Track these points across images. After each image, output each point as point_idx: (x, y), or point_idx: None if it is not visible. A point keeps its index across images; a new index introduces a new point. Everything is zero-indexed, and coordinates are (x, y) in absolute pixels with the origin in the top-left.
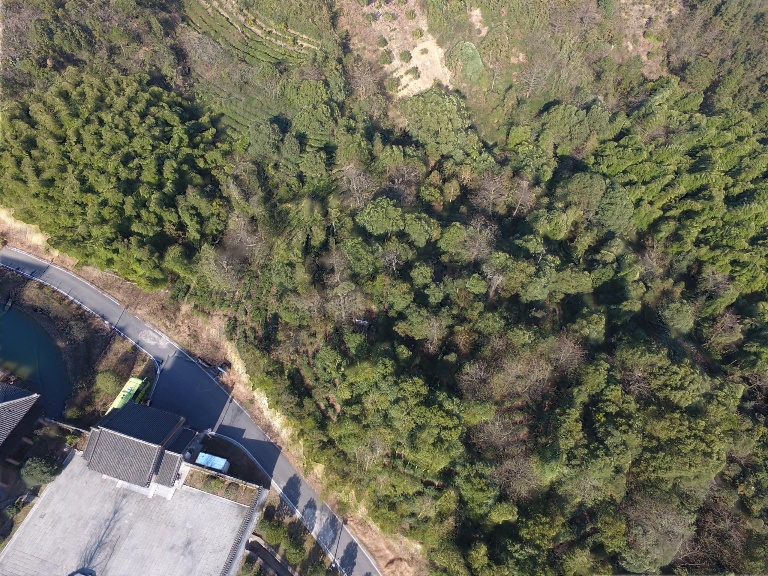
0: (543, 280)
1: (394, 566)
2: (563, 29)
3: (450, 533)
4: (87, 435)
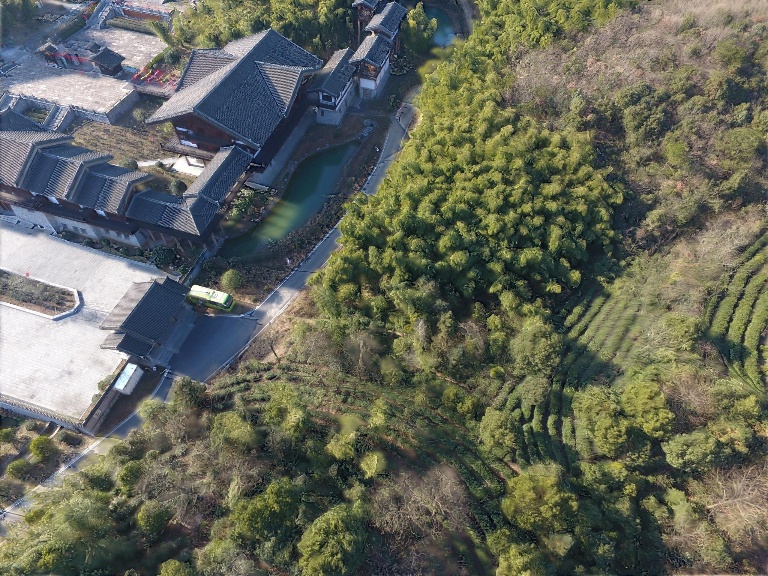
0: None
1: None
2: None
3: None
4: None
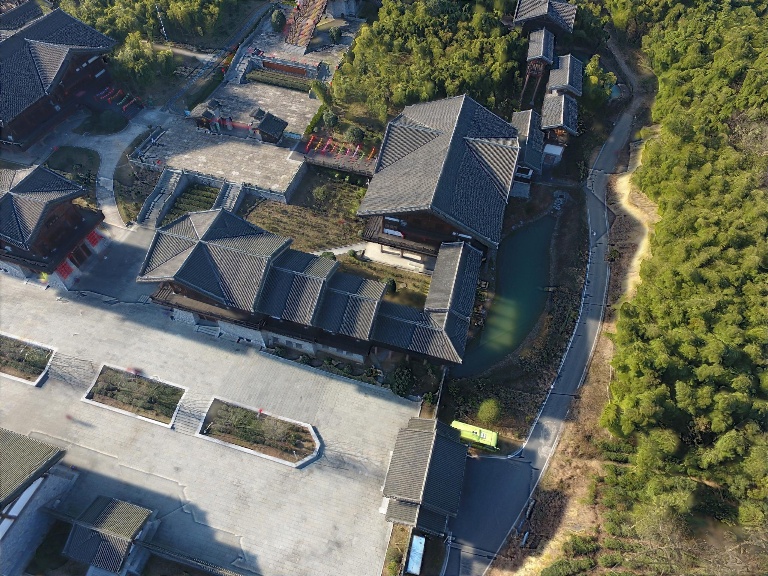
0: None
1: None
2: None
3: None
4: None
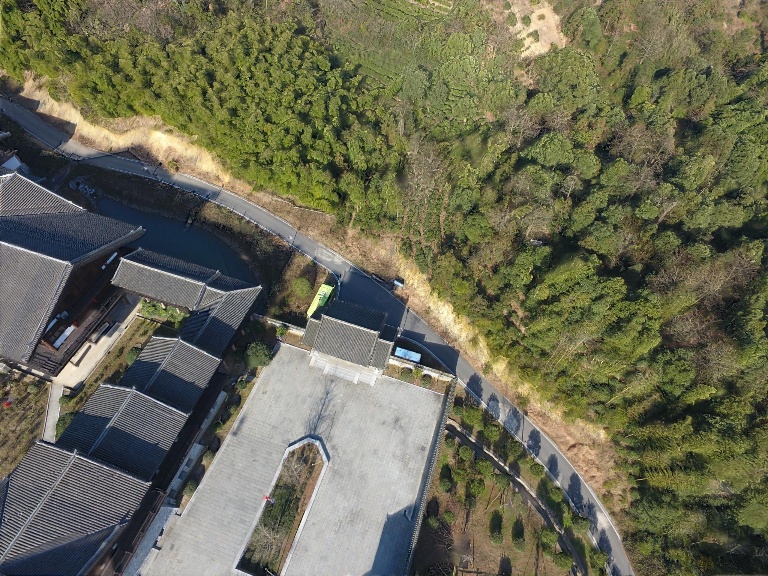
0: (710, 208)
1: (576, 449)
2: (671, 2)
3: (643, 414)
4: (288, 331)
